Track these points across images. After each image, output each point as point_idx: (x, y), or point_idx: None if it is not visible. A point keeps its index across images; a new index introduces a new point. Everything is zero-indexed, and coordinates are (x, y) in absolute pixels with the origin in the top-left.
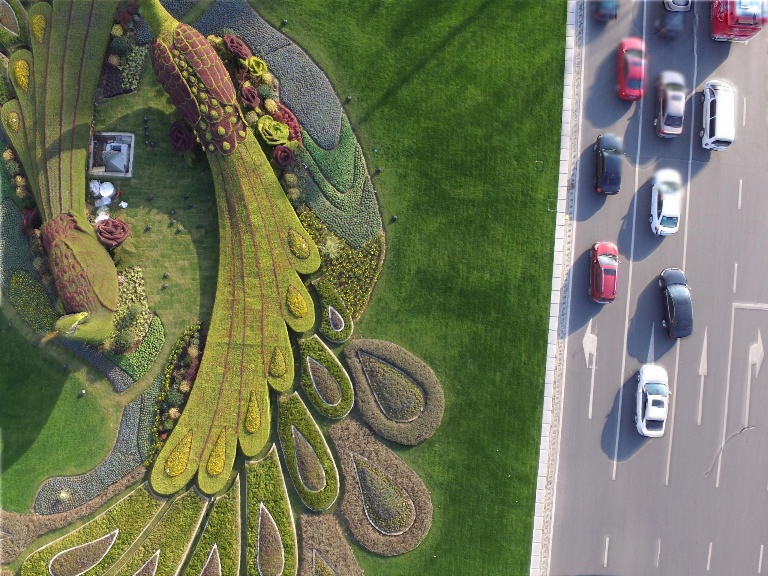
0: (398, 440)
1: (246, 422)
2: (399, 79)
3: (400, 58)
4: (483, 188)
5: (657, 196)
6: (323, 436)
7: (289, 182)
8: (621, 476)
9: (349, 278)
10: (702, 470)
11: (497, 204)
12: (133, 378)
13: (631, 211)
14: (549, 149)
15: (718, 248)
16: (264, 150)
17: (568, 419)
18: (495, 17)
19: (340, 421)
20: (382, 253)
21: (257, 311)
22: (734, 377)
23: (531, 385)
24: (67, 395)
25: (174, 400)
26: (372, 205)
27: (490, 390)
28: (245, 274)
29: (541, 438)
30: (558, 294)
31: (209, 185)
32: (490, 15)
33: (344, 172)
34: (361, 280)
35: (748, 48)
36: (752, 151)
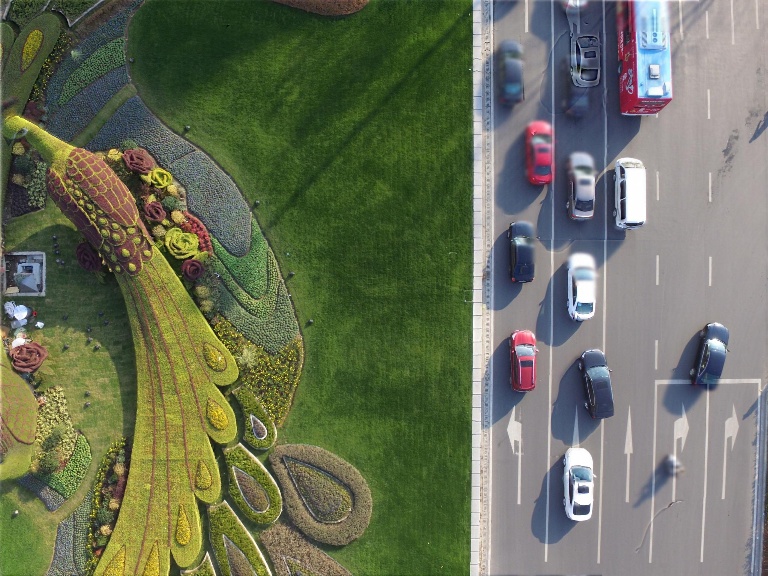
0: (328, 542)
1: (177, 535)
2: (306, 179)
3: (306, 158)
4: (398, 284)
5: (572, 281)
6: (255, 542)
7: (201, 295)
8: (553, 558)
9: (269, 385)
10: (632, 546)
11: (413, 299)
12: (64, 496)
13: (549, 295)
14: (462, 239)
15: (637, 326)
16: (175, 262)
17: (497, 506)
18: (400, 108)
19: (271, 526)
20: (300, 357)
21: (178, 427)
22: (660, 453)
23: (458, 476)
24: (1, 516)
25: (104, 519)
26: (287, 310)
27: (417, 485)
28: (163, 391)
29: (471, 527)
30: (479, 385)
31: (123, 301)
32: (395, 106)
33: (257, 278)
34: (281, 386)
35: (659, 120)
36: (668, 225)
